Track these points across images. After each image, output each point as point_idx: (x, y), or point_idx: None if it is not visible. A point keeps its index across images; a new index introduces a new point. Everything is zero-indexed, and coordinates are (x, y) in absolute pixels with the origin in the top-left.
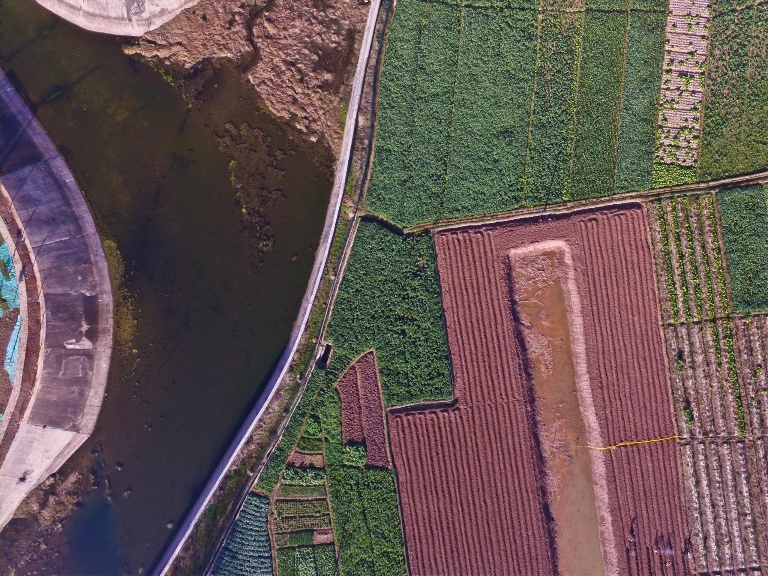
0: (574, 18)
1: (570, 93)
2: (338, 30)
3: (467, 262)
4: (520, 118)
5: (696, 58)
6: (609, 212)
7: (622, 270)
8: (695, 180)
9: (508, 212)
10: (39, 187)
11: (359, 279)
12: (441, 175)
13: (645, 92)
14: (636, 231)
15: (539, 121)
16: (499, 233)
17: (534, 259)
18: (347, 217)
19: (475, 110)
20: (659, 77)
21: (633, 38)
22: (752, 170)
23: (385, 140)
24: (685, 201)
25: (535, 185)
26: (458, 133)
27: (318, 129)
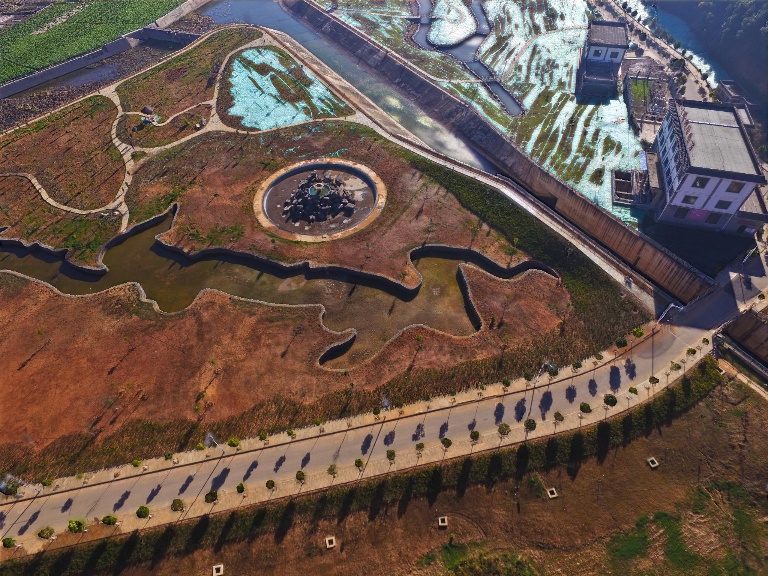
0: None
1: None
2: None
3: None
4: None
5: None
6: None
7: None
8: None
9: None
10: (291, 2)
11: None
12: (160, 2)
13: None
14: None
15: None
16: None
17: None
18: None
19: None
20: None
21: None
22: None
23: None
24: None
25: None
26: None
27: None
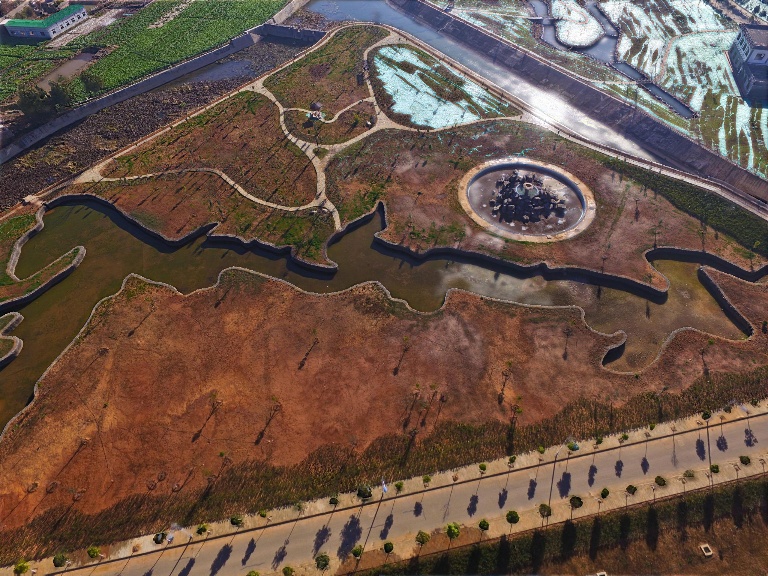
0: None
1: None
2: None
3: None
4: None
5: None
6: None
7: None
8: None
9: None
10: None
11: None
12: None
13: None
14: None
15: None
16: None
17: None
18: None
19: None
20: None
21: None
22: None
23: None
24: None
25: None
26: (258, 2)
27: None
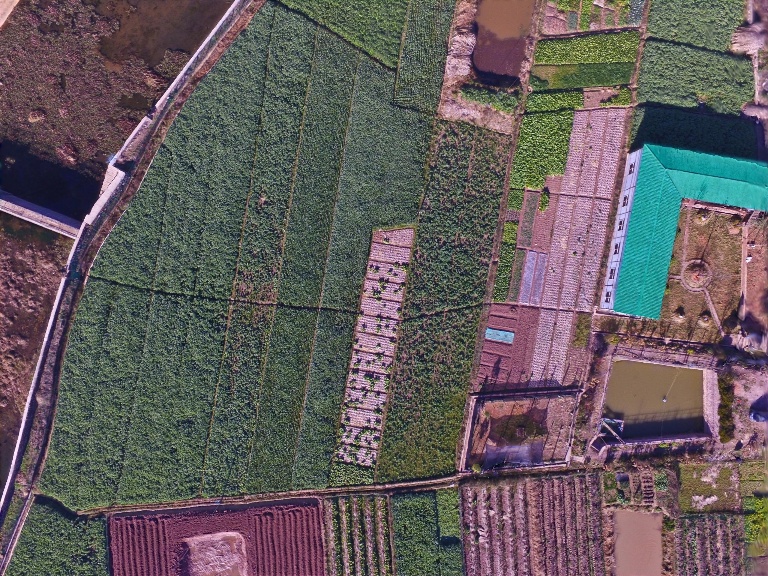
0: (265, 311)
1: (254, 387)
2: (36, 295)
3: (138, 549)
4: (201, 409)
5: (383, 359)
6: (285, 507)
7: (293, 566)
8: (372, 481)
9: (184, 501)
10: None
11: (24, 563)
12: (118, 461)
13: (326, 393)
14: (310, 528)
15: (221, 413)
16: (173, 522)
17: (213, 543)
18: (21, 495)
19: (155, 399)
20: (343, 377)
21: (319, 338)
22: (428, 475)
23: (63, 422)
24: (359, 502)
25: (213, 476)
26: (137, 421)
27: (8, 395)
